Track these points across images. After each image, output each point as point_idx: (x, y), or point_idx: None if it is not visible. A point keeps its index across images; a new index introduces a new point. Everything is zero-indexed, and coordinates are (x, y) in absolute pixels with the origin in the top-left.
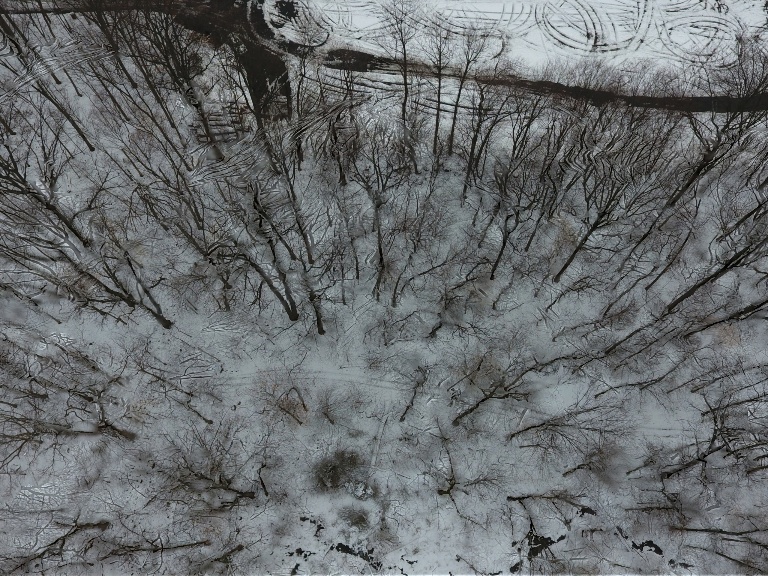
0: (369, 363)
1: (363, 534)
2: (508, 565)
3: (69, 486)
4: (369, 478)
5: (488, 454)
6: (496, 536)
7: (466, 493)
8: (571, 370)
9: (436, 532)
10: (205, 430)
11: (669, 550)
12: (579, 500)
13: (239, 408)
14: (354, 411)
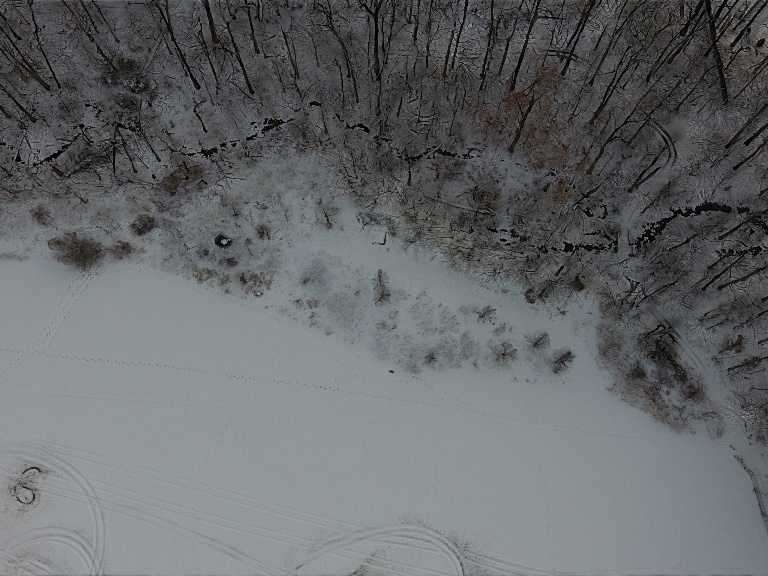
0: None
1: (133, 114)
2: (245, 136)
3: None
4: (143, 78)
5: None
6: (233, 108)
7: (218, 89)
8: (313, 5)
9: (191, 114)
10: None
11: (374, 128)
12: (308, 95)
13: (44, 30)
14: (136, 34)
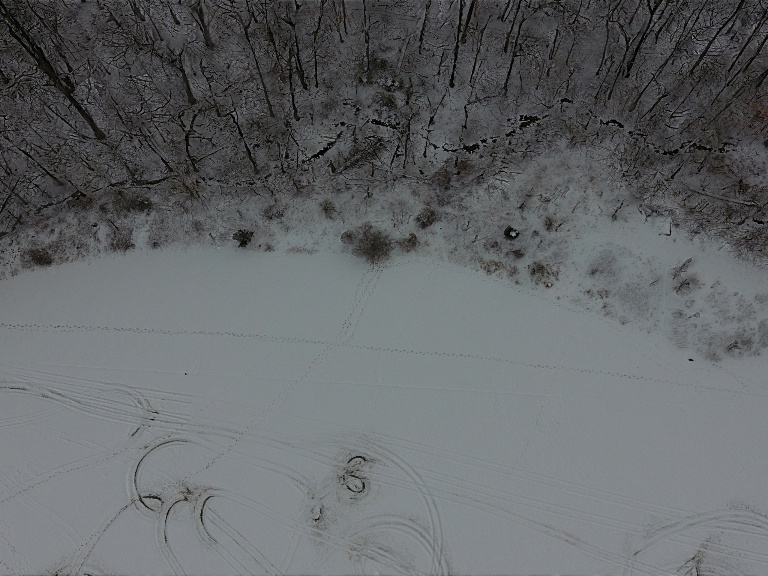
0: (395, 2)
1: (392, 112)
2: (504, 132)
3: (165, 76)
4: (396, 77)
5: (489, 61)
6: (495, 105)
7: None
8: None
9: (448, 111)
10: (268, 44)
11: (629, 123)
12: (559, 92)
13: None
14: (384, 34)
